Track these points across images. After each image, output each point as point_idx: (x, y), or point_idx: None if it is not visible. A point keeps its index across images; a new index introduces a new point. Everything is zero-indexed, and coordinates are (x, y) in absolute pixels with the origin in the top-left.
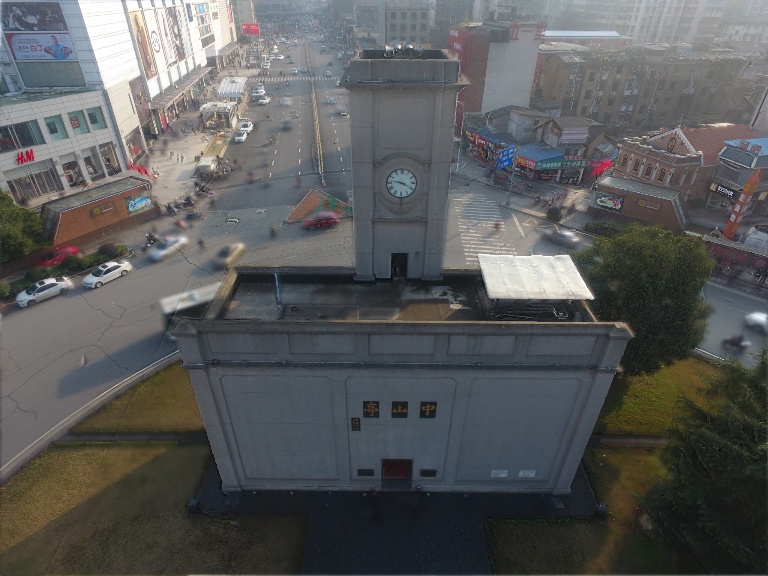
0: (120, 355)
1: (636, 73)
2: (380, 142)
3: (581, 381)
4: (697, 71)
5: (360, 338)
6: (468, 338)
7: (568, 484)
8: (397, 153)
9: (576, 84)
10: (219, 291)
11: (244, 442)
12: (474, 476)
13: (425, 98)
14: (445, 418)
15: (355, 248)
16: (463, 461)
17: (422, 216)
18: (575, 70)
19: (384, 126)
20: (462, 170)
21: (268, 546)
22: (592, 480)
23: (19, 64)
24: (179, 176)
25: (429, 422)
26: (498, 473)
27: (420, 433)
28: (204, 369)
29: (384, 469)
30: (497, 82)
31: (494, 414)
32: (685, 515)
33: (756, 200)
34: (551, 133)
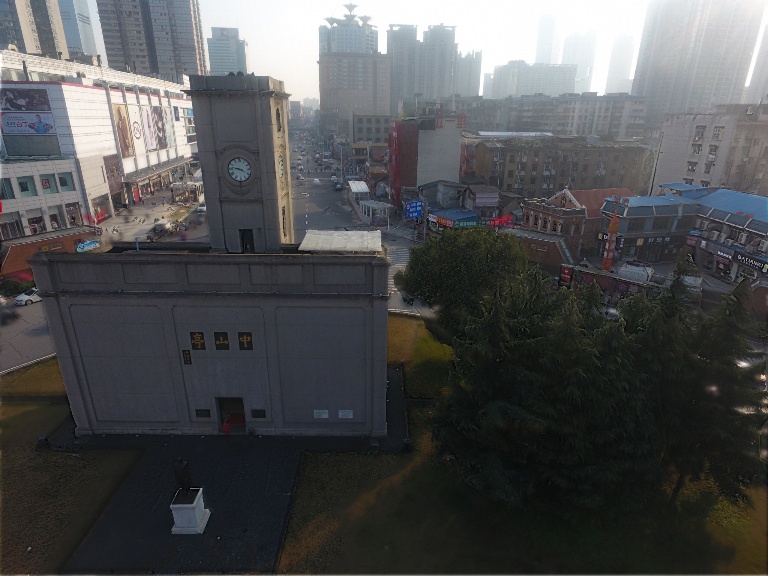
0: (26, 348)
1: (551, 157)
2: (219, 136)
3: (364, 310)
4: (605, 156)
5: (179, 268)
6: (265, 268)
7: (383, 425)
8: (233, 145)
9: (500, 165)
10: (89, 252)
11: (93, 378)
12: (300, 418)
13: (248, 103)
14: (261, 350)
15: (209, 224)
16: (286, 399)
17: (259, 197)
18: (497, 154)
19: (221, 124)
20: (393, 230)
21: (99, 469)
22: (411, 427)
23: (5, 137)
24: (136, 233)
25: (249, 355)
26: (320, 414)
27: (243, 367)
28: (55, 297)
29: (227, 419)
30: (428, 162)
31: (302, 346)
32: (449, 421)
33: (636, 246)
34: (468, 198)
